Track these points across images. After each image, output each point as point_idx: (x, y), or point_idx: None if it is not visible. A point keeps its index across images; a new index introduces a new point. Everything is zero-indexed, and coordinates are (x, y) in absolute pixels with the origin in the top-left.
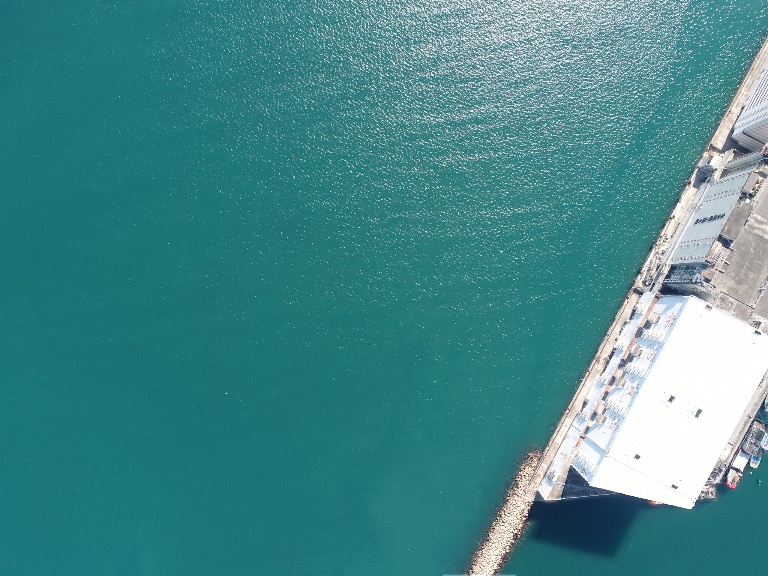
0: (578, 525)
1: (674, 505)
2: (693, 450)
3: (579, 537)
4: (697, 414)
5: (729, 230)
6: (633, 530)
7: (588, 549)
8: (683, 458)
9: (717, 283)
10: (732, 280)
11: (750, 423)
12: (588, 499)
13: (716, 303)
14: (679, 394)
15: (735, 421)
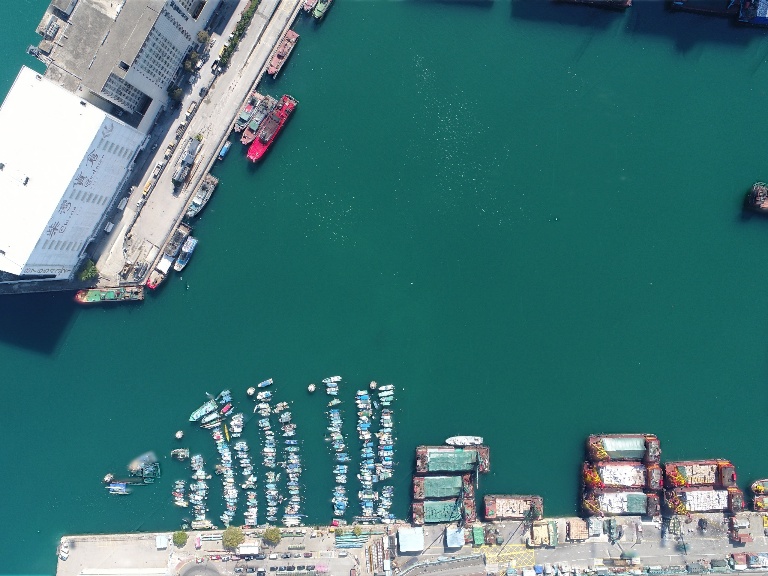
0: (14, 321)
1: (3, 270)
2: (16, 215)
3: (17, 333)
4: (26, 182)
5: (59, 1)
6: (69, 329)
7: (26, 346)
8: (8, 223)
9: (56, 56)
10: (70, 54)
11: (176, 227)
12: (23, 296)
13: (47, 74)
14: (9, 162)
15: (60, 190)
